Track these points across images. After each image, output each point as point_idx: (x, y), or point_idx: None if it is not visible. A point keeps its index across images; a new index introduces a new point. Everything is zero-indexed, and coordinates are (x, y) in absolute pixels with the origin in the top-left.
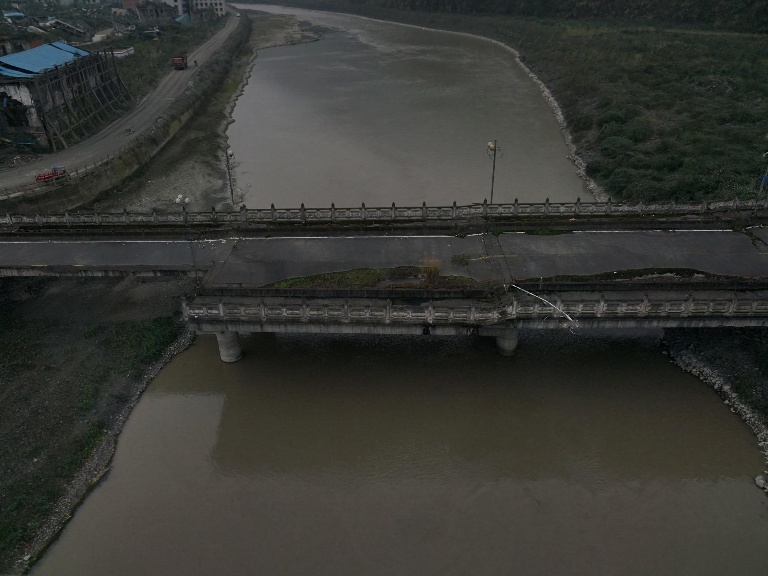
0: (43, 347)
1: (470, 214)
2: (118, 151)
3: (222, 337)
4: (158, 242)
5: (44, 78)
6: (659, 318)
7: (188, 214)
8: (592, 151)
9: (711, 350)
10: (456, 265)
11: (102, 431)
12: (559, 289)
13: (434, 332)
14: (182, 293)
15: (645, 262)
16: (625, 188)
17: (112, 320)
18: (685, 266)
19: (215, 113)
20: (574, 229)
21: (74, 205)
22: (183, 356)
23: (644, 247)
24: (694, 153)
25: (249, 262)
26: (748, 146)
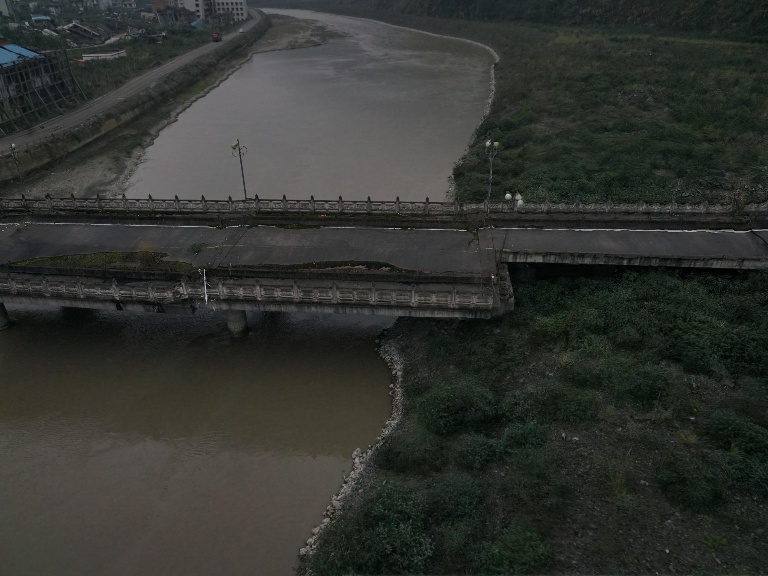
0: None
1: (245, 208)
2: (25, 145)
3: None
4: None
5: None
6: (313, 304)
7: (2, 200)
8: (474, 156)
9: (409, 340)
10: (189, 252)
11: None
12: (247, 275)
13: (126, 308)
14: None
15: (351, 255)
16: None
17: None
18: (382, 260)
19: (162, 113)
20: (323, 224)
21: None
22: None
23: (366, 242)
24: (539, 160)
25: (17, 243)
26: (595, 154)
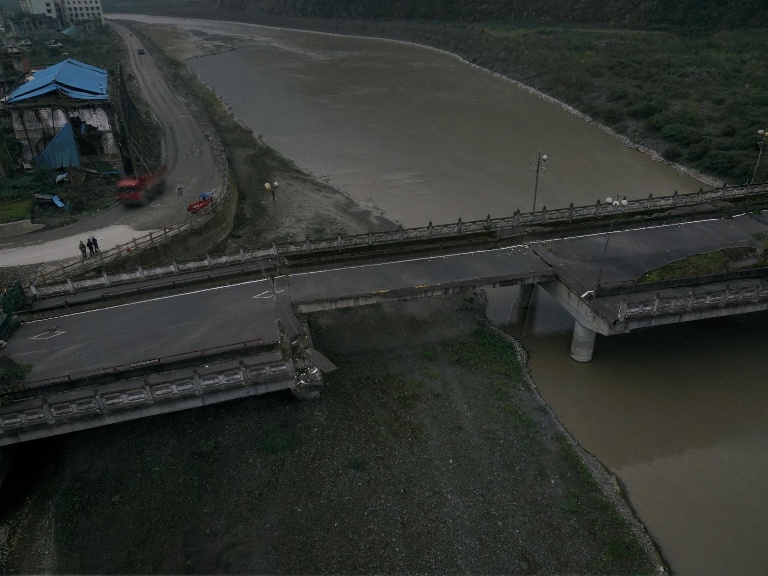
0: (399, 377)
1: (710, 198)
2: None
3: (588, 337)
4: (461, 255)
5: (116, 99)
6: None
7: (463, 224)
8: (651, 139)
9: None
10: (765, 242)
11: (568, 443)
12: None
13: None
14: (461, 305)
15: None
16: (734, 167)
17: (429, 340)
18: None
19: (235, 128)
20: None
21: (225, 233)
22: (533, 364)
23: None
24: None
25: (587, 262)
26: None
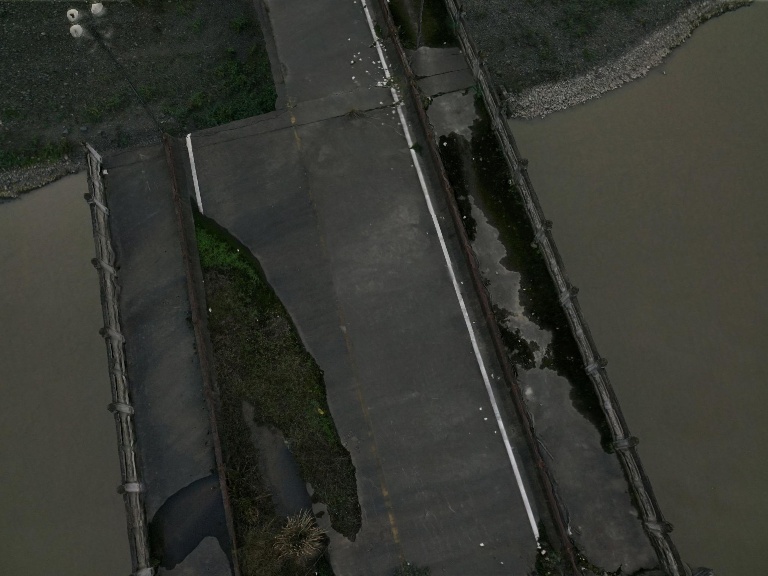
0: None
1: (671, 571)
2: None
3: None
4: None
5: None
6: None
7: None
8: None
9: None
10: None
11: (63, 155)
12: None
13: None
14: None
15: None
16: None
17: None
18: None
19: None
20: None
21: None
22: None
23: None
24: None
25: (300, 164)
26: None
